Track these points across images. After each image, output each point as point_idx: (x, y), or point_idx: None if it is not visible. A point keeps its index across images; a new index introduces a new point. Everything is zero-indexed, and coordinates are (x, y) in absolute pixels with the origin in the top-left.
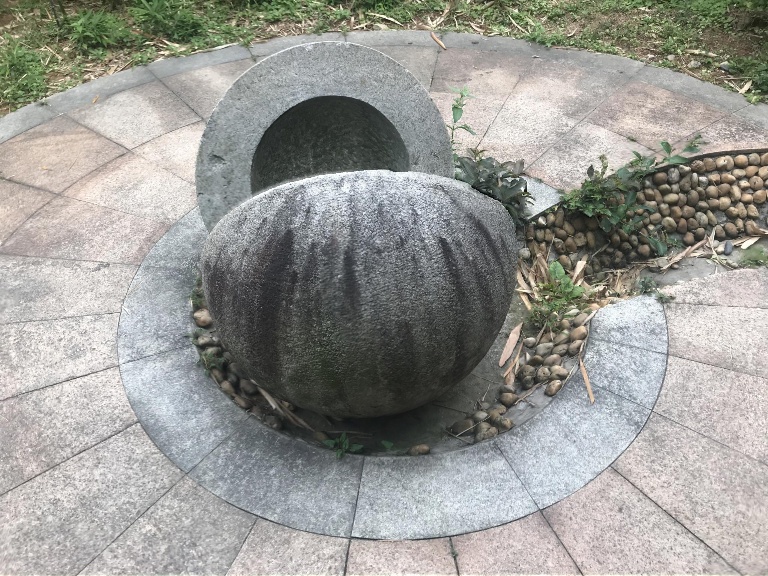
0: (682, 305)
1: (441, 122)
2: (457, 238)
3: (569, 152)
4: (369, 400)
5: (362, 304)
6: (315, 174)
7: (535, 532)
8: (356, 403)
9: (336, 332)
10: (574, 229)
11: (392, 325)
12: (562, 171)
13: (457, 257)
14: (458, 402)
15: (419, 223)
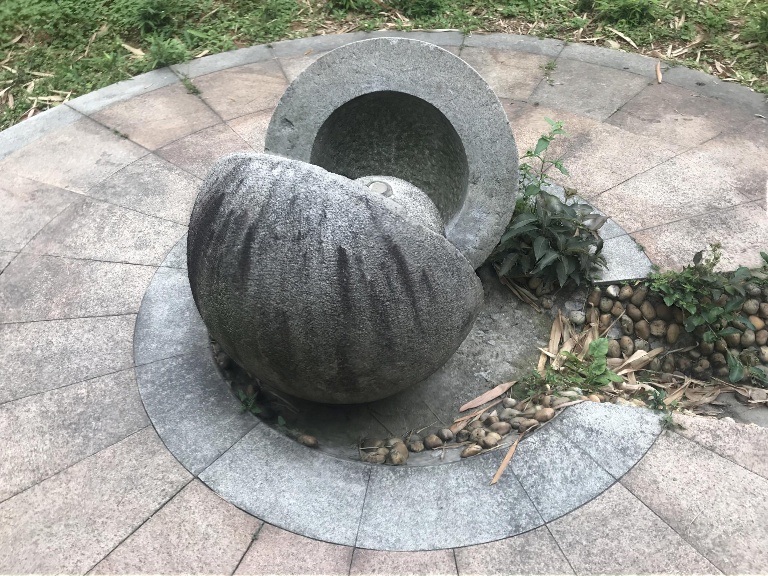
0: (686, 440)
1: (513, 149)
2: (359, 253)
3: (704, 230)
4: (260, 371)
5: (249, 279)
6: (395, 165)
7: (333, 562)
8: (252, 368)
9: (227, 295)
10: (655, 314)
11: (271, 309)
12: (677, 247)
13: (352, 271)
14: (393, 422)
15: (324, 225)
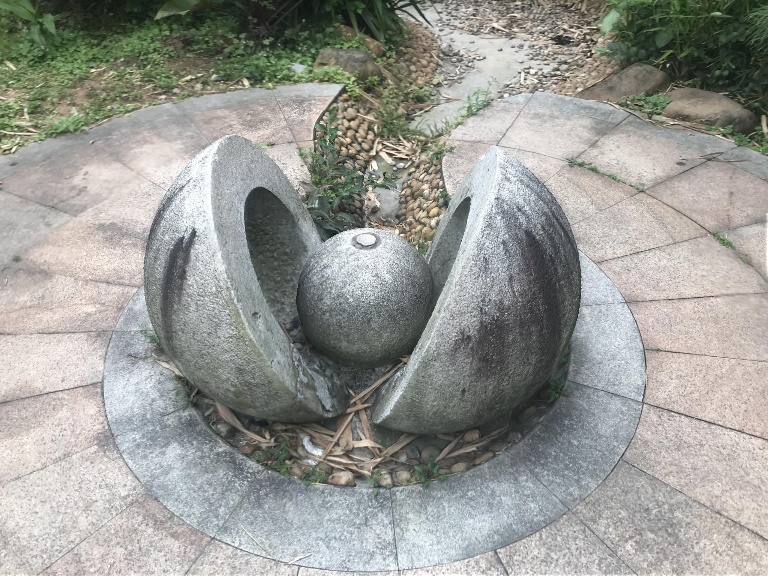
0: None
1: None
2: None
3: None
4: None
5: (573, 244)
6: None
7: (642, 309)
8: None
9: None
10: None
11: None
12: None
13: None
14: None
15: None
